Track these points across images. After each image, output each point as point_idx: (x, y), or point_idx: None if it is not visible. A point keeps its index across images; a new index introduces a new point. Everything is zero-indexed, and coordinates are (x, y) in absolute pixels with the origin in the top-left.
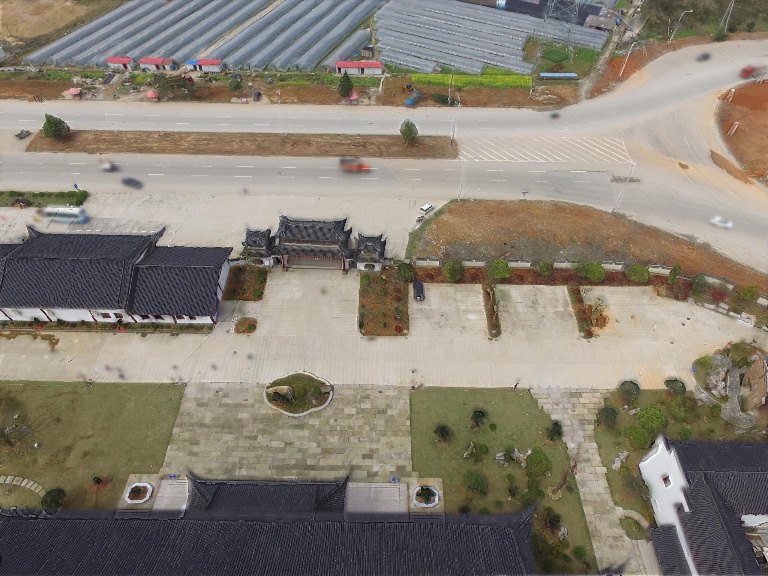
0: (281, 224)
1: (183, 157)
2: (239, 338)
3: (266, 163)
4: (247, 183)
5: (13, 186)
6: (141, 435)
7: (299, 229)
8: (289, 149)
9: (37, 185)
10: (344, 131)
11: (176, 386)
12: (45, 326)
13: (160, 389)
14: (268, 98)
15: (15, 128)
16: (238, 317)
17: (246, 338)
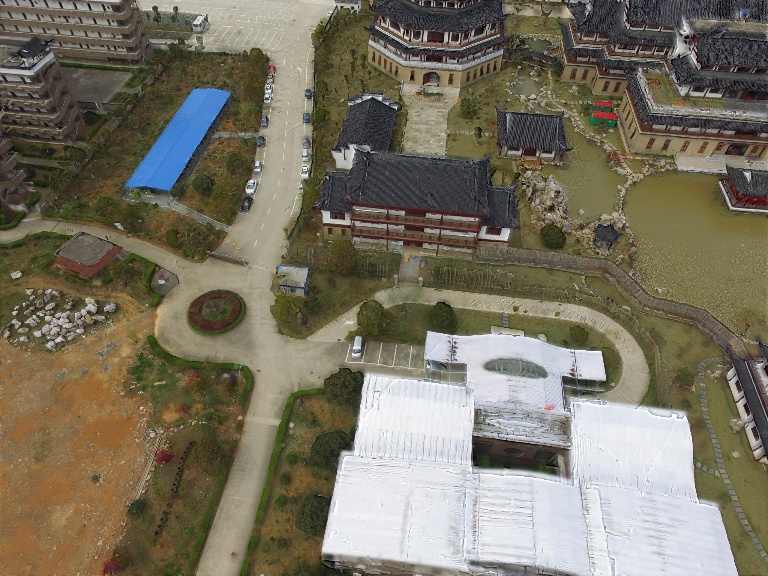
0: None
1: None
2: None
3: None
4: None
5: None
6: None
7: None
8: None
9: None
10: None
11: None
12: (523, 2)
13: None
14: None
15: None
16: None
17: None
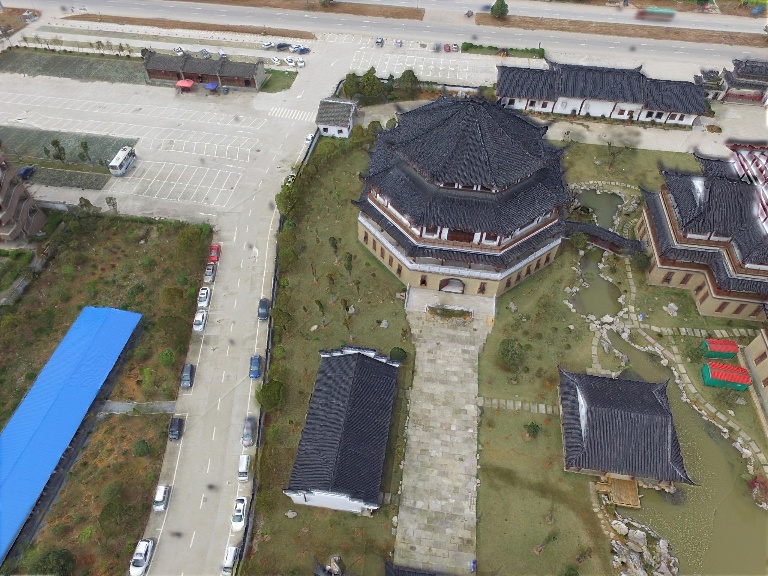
0: (725, 69)
1: (595, 36)
2: (713, 135)
3: (662, 43)
4: (655, 54)
5: (485, 44)
6: (684, 173)
7: (754, 67)
8: (674, 36)
9: (501, 45)
10: (709, 28)
11: (688, 154)
12: (575, 118)
13: (678, 155)
14: (633, 5)
15: (457, 11)
16: (706, 124)
17: (718, 135)
